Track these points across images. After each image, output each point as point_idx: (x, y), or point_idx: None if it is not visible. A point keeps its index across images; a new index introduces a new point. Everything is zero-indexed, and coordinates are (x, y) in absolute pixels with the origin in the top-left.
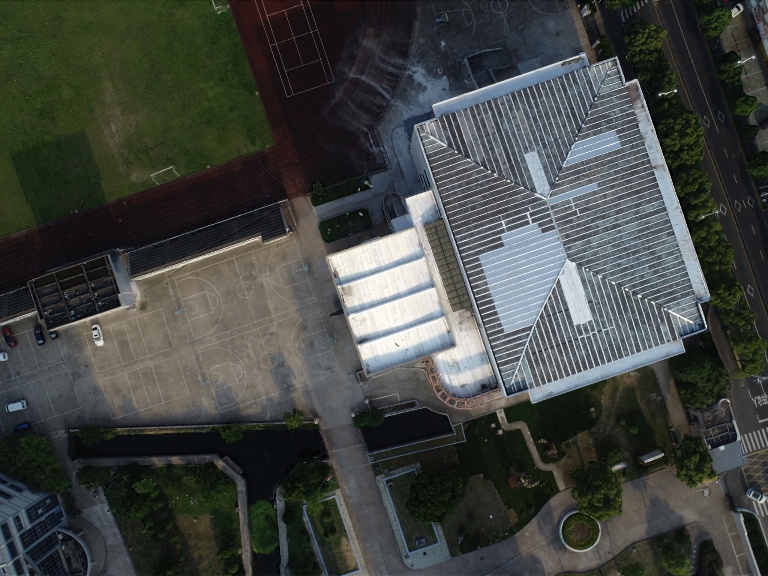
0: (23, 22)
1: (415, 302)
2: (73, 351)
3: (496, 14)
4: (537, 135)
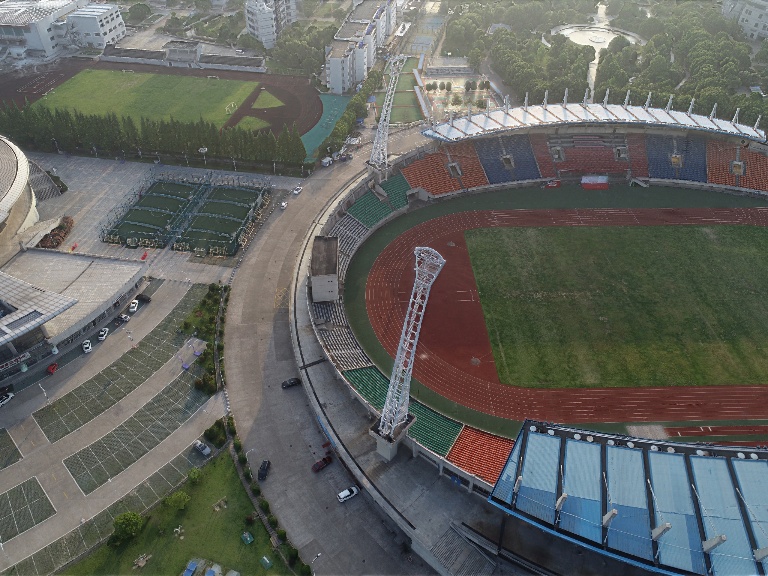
0: (123, 109)
1: None
2: None
3: None
4: None
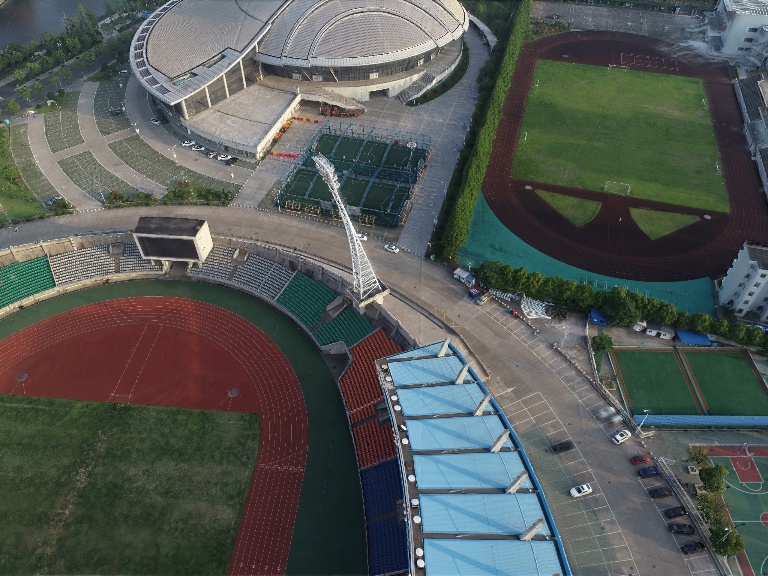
0: (595, 115)
1: None
2: None
3: (665, 26)
4: None
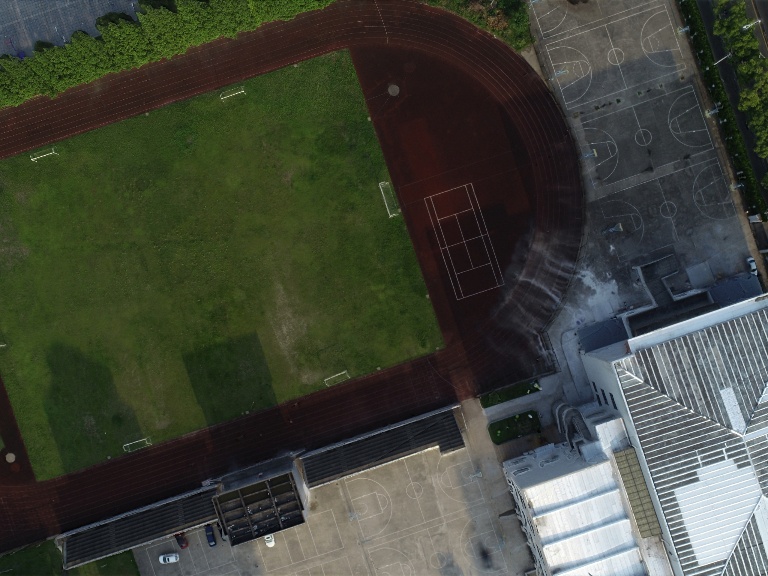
0: (196, 225)
1: (608, 533)
2: (243, 551)
3: (665, 219)
4: (732, 371)
